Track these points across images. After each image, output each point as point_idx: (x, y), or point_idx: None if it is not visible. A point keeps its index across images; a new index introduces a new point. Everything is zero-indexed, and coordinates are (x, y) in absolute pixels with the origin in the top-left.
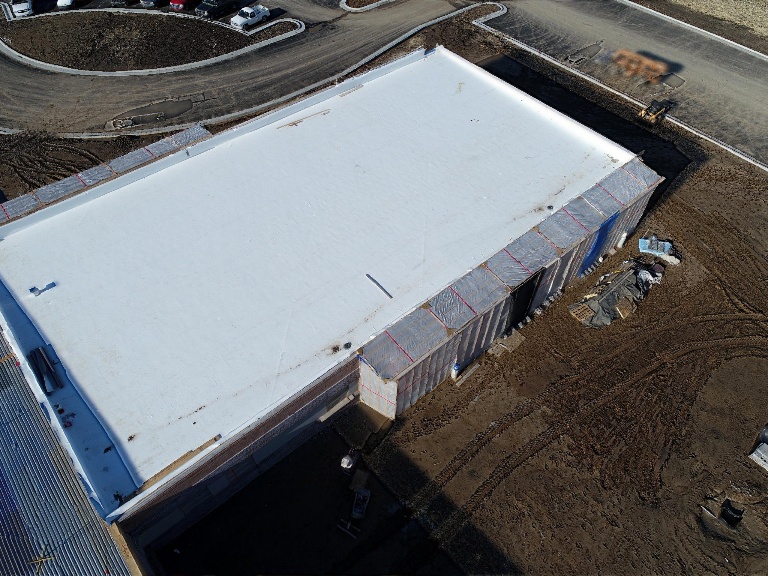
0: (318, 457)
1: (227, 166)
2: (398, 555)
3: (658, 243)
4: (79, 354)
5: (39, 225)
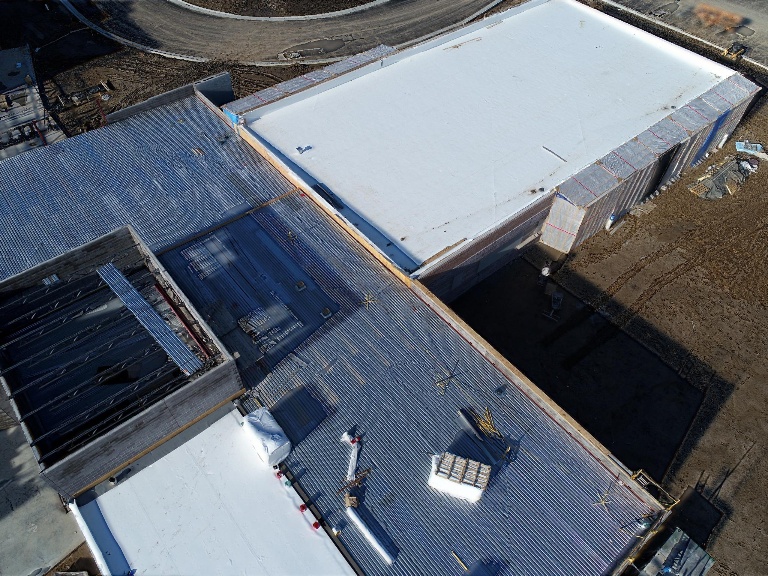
0: (516, 275)
1: (413, 74)
2: (590, 332)
3: (751, 145)
4: (346, 189)
5: (283, 110)
